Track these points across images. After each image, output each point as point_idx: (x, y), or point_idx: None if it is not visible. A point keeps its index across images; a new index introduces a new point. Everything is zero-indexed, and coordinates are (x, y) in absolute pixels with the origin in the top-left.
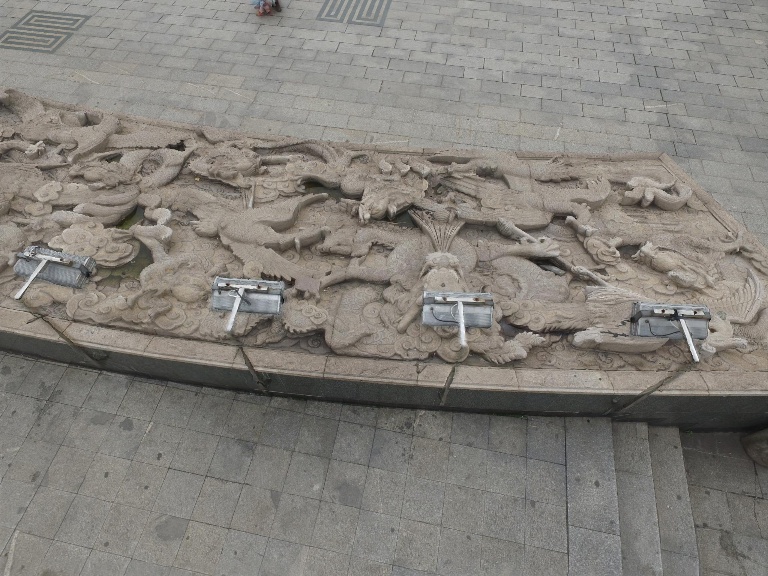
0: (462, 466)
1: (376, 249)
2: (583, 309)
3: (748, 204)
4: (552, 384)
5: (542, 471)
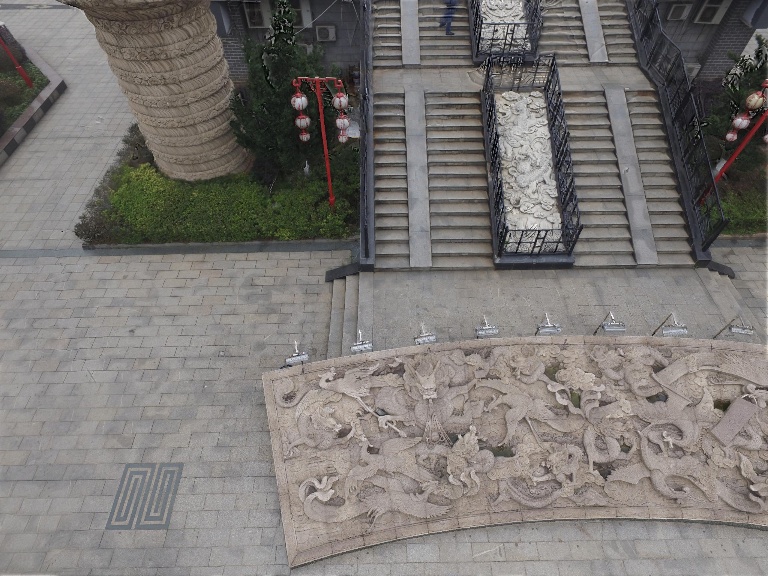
0: (407, 344)
1: (461, 413)
2: (373, 383)
3: (239, 538)
4: (386, 351)
5: (381, 347)
